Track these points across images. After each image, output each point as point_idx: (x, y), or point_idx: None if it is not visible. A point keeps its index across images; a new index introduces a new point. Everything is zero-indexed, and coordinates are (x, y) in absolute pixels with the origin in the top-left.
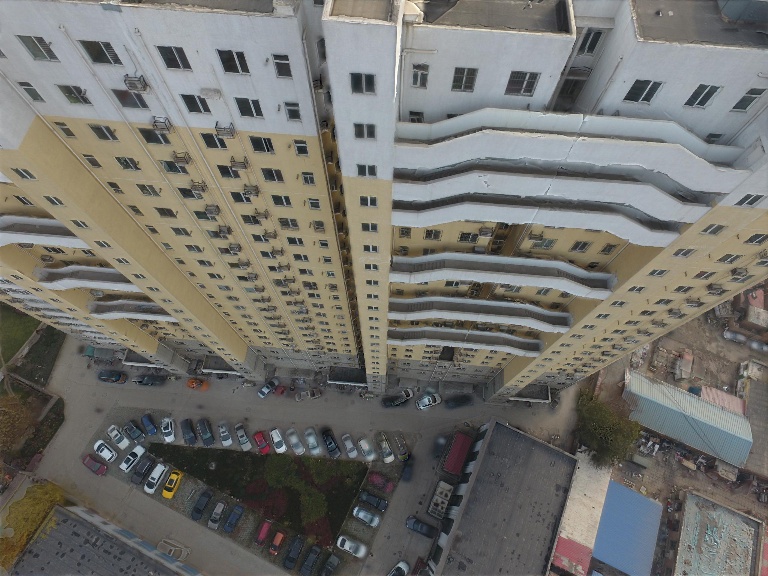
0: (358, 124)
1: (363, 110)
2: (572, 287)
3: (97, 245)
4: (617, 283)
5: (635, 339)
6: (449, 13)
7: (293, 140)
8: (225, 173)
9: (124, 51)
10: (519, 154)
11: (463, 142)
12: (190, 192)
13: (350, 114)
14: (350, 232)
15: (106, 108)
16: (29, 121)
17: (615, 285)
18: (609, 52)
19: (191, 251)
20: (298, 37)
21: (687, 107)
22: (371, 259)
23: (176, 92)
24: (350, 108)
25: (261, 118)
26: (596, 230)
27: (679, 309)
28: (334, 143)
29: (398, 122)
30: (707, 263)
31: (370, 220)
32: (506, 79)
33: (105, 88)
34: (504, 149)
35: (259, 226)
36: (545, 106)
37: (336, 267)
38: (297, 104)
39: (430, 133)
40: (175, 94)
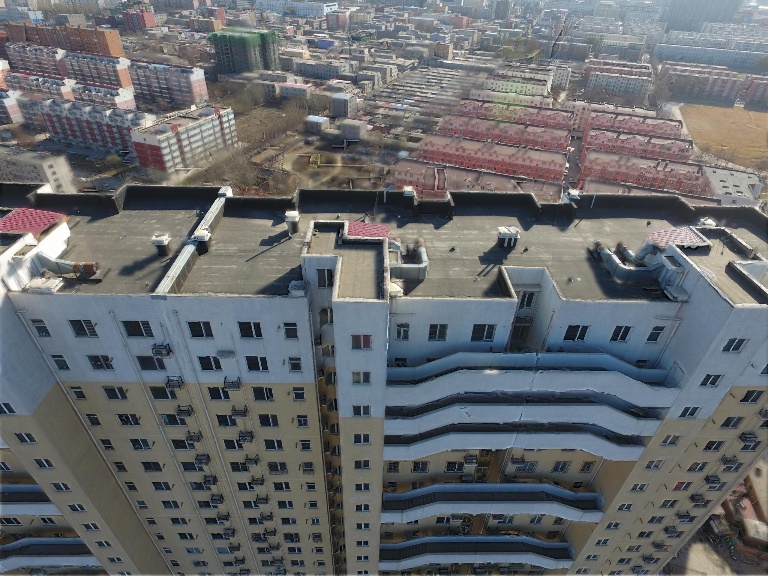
0: (356, 372)
1: (360, 361)
2: (564, 511)
3: (70, 510)
4: (605, 502)
5: (643, 569)
6: (420, 287)
7: (292, 388)
8: (223, 422)
9: (159, 327)
10: (492, 387)
11: (444, 381)
12: (183, 443)
13: (349, 365)
14: (343, 471)
15: (126, 372)
16: (49, 388)
17: (604, 505)
18: (543, 307)
19: (167, 508)
20: (306, 310)
21: (613, 342)
22: (362, 499)
23: (195, 355)
24: (350, 360)
25: (266, 371)
26: (571, 449)
27: (674, 526)
28: (327, 387)
29: (387, 368)
30: (680, 473)
31: (363, 457)
32: (470, 330)
33: (131, 356)
34: (479, 384)
35: (247, 473)
36: (504, 348)
37: (322, 512)
38: (299, 358)
39: (414, 375)
40: (193, 357)
